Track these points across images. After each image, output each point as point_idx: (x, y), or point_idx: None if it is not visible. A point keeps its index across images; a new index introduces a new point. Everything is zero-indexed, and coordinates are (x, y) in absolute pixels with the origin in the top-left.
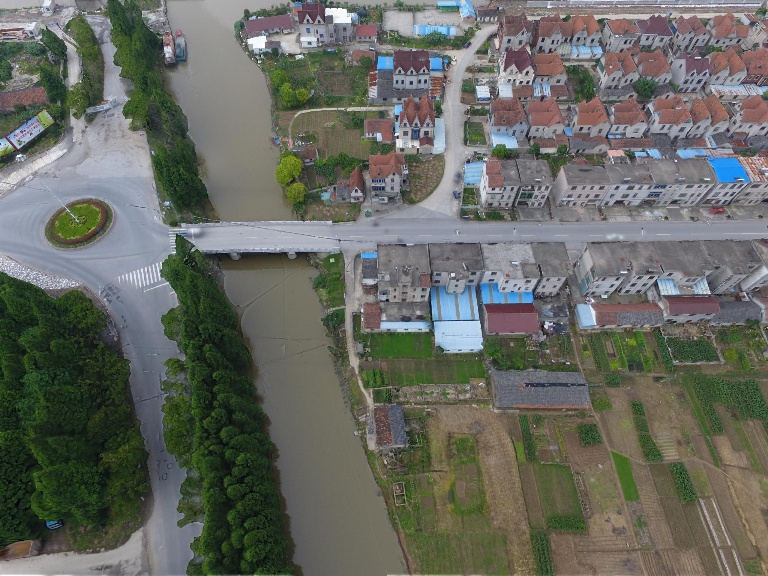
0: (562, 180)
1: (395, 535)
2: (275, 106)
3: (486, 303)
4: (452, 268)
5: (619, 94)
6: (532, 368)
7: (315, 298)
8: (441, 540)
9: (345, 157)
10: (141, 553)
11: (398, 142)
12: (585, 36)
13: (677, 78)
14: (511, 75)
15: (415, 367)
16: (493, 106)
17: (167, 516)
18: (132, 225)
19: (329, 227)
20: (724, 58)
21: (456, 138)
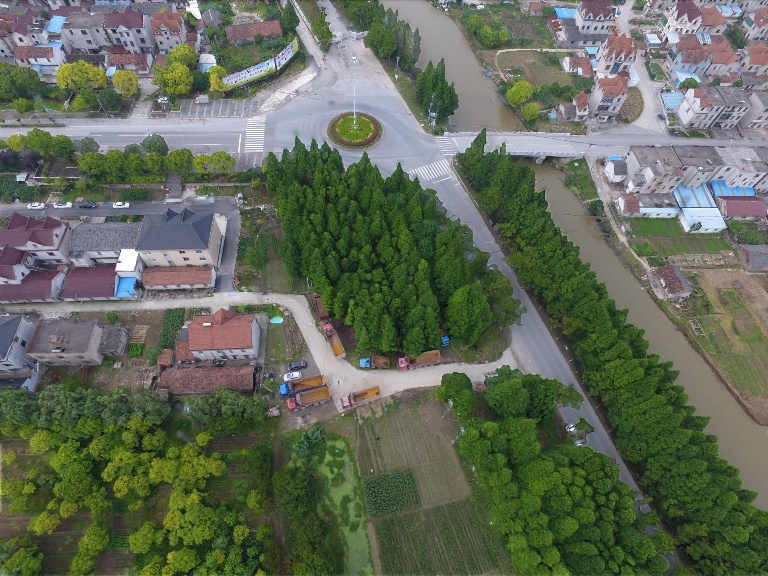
0: (754, 104)
1: (700, 357)
2: (477, 46)
3: (718, 195)
4: (698, 163)
5: (767, 44)
6: (765, 244)
7: (570, 193)
8: (739, 358)
9: (558, 86)
10: (516, 364)
11: (600, 75)
12: None
13: None
14: (680, 24)
15: (673, 242)
16: (679, 46)
17: (525, 340)
18: (400, 133)
19: (567, 138)
20: None
21: (642, 75)
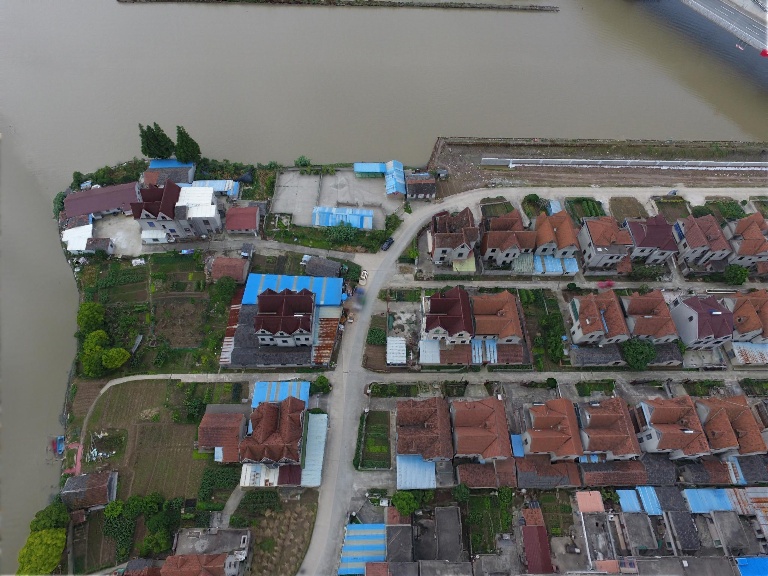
0: None
1: None
2: (74, 369)
3: None
4: None
5: (599, 361)
6: None
7: None
8: None
9: (152, 505)
10: None
11: (244, 473)
12: (554, 247)
13: (684, 332)
14: (437, 334)
15: None
16: (398, 416)
17: None
18: None
19: None
20: (755, 312)
21: (343, 450)
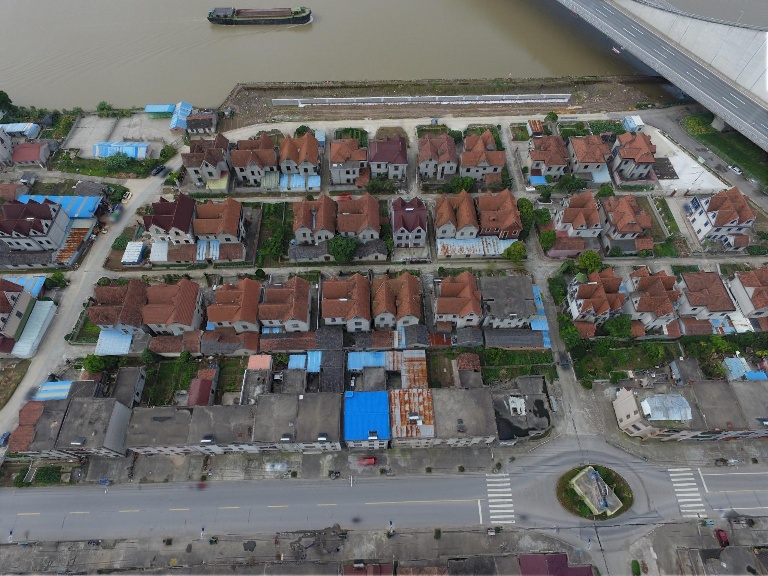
0: None
1: None
2: None
3: None
4: None
5: (309, 256)
6: None
7: None
8: None
9: None
10: None
11: None
12: (295, 165)
13: None
14: (160, 234)
15: None
16: (97, 295)
17: None
18: None
19: None
20: (446, 208)
21: (63, 330)
